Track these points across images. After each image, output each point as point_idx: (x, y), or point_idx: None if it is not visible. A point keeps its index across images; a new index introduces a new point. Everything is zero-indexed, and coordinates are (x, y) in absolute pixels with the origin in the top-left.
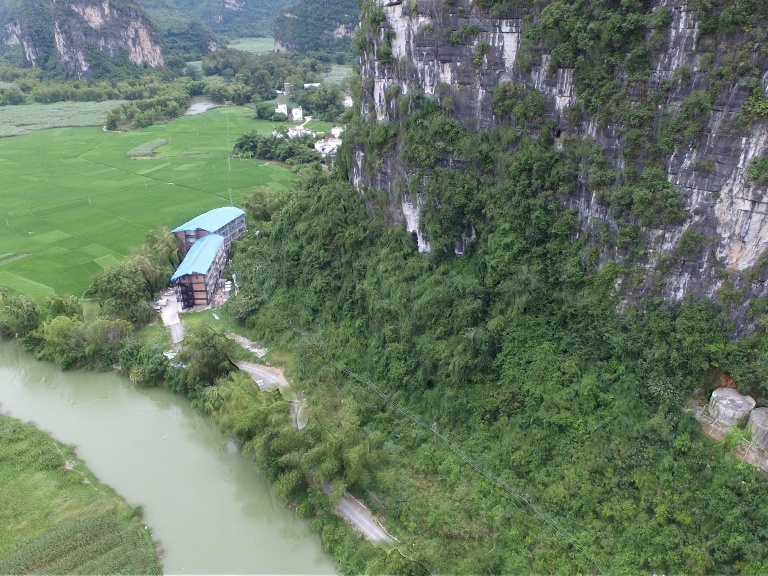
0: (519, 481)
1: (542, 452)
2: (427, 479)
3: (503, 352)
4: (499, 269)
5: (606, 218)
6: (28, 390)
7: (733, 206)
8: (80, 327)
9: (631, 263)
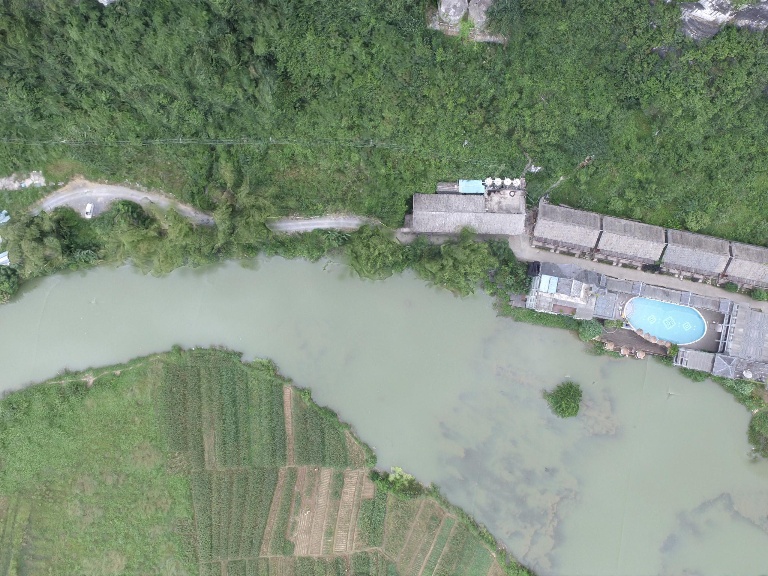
0: (354, 132)
1: (356, 108)
2: (293, 169)
3: (281, 62)
4: (228, 2)
5: None
6: None
7: None
8: None
9: None
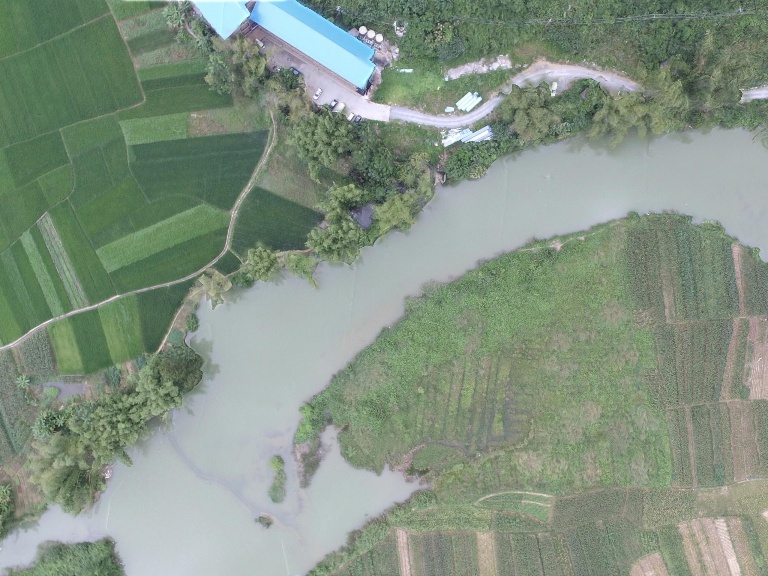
0: None
1: None
2: (740, 42)
3: None
4: None
5: None
6: (401, 260)
7: None
8: (416, 197)
9: None
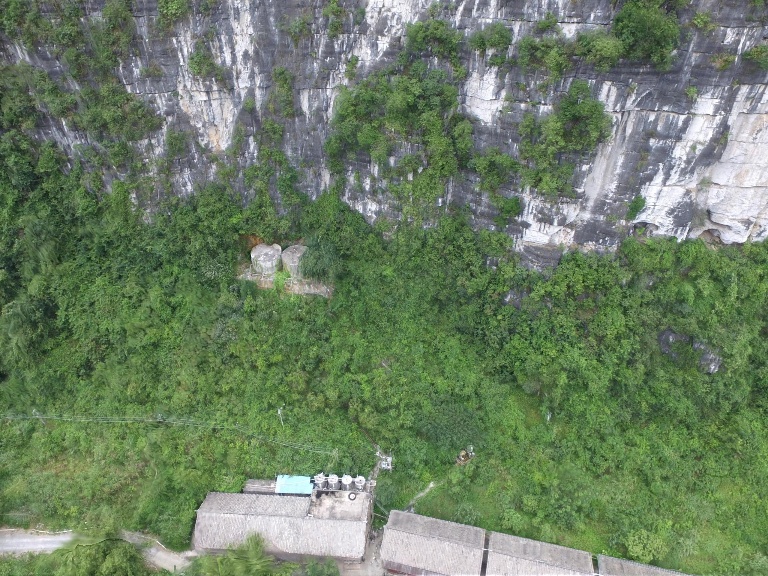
0: (145, 408)
1: (150, 373)
2: (59, 461)
3: (61, 308)
4: (5, 230)
5: (89, 142)
6: None
7: (193, 99)
8: None
9: (135, 177)
